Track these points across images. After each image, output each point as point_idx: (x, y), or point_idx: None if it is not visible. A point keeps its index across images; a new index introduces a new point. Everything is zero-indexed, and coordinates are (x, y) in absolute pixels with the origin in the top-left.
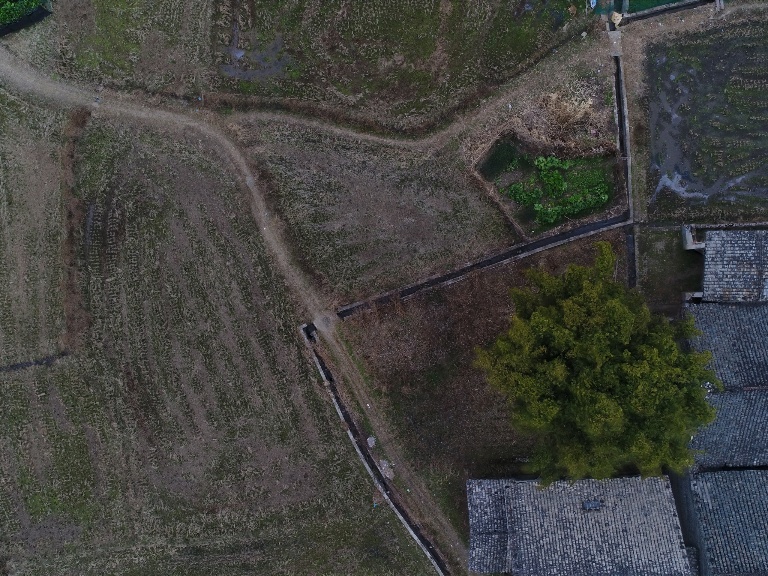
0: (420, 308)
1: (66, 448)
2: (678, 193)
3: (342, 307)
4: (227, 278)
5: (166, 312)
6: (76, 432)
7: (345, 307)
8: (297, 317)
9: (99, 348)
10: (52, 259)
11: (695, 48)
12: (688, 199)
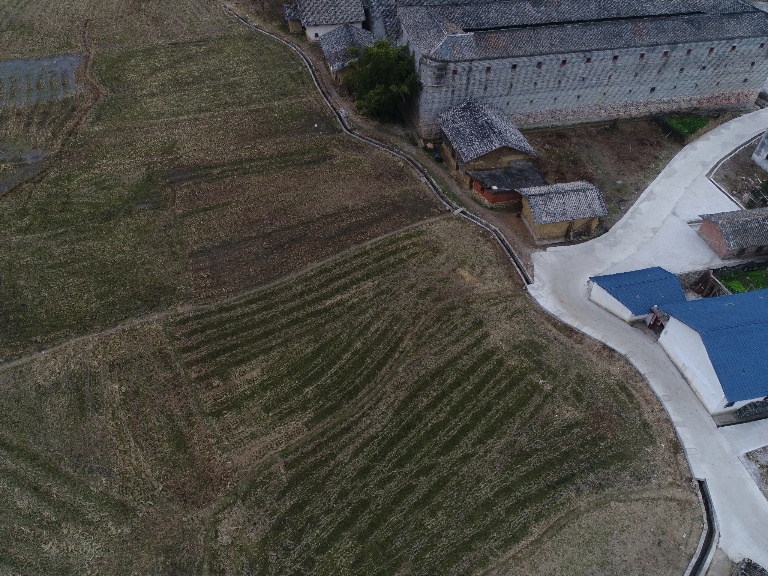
0: (267, 2)
1: None
2: None
3: (237, 2)
4: (194, 2)
5: (170, 8)
6: None
7: (238, 2)
8: (220, 5)
9: None
10: (128, 1)
11: None
12: None
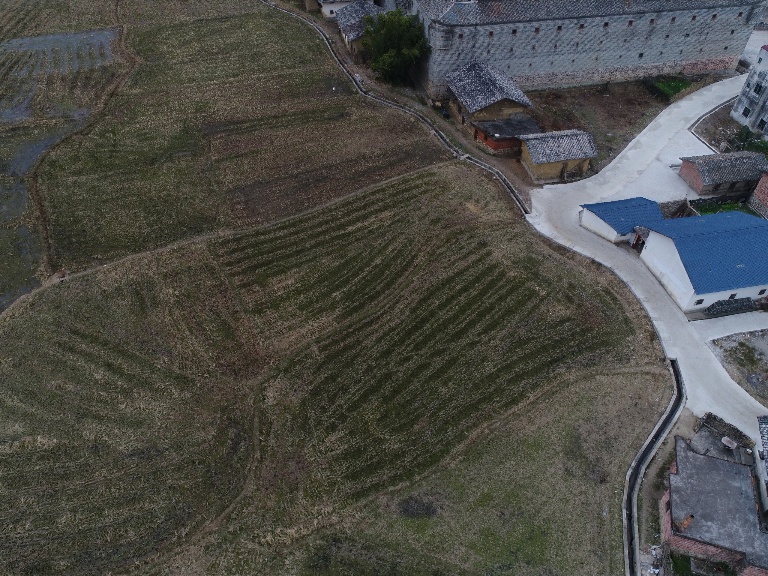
0: None
1: (152, 8)
2: None
3: None
4: None
5: None
6: None
7: None
8: None
9: None
10: None
11: None
12: None
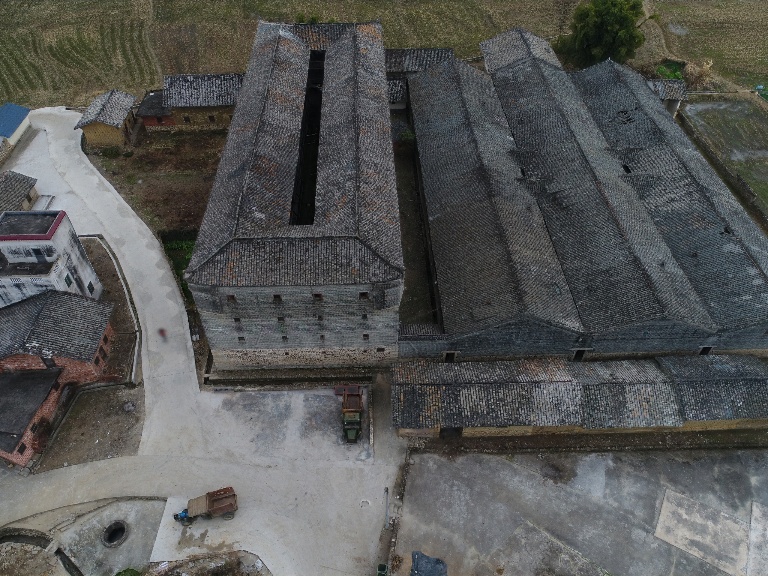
0: None
1: (520, 0)
2: (686, 108)
3: None
4: None
5: None
6: (526, 1)
7: None
8: None
9: (558, 5)
10: None
11: (758, 112)
12: (685, 110)
